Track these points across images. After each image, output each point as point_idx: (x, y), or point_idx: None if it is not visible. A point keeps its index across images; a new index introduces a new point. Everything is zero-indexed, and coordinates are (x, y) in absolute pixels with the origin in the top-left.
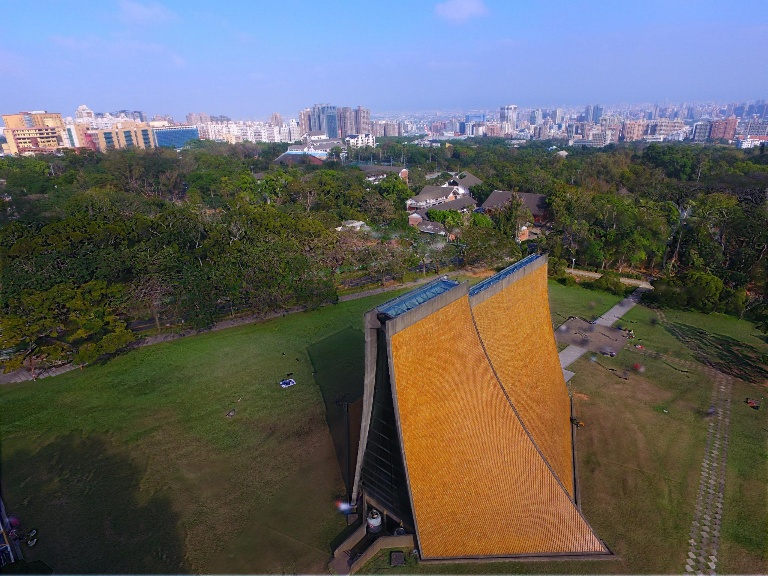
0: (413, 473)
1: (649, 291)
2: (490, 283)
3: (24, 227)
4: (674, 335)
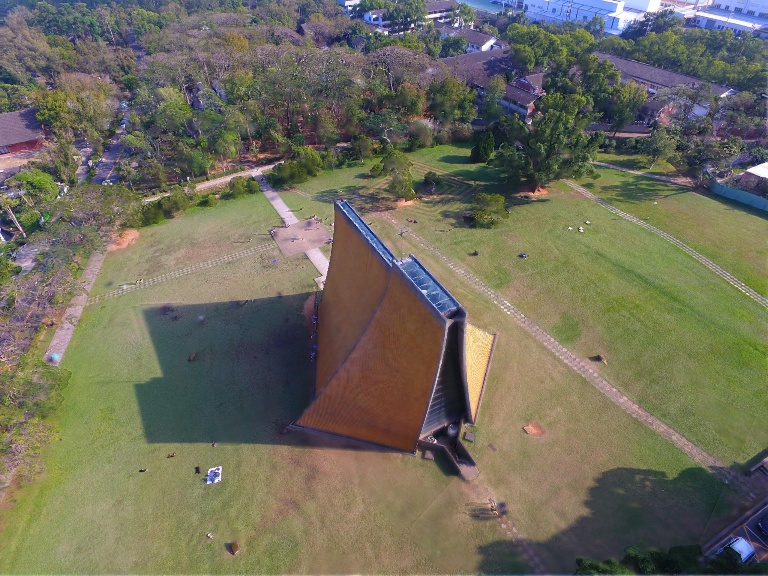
0: None
1: (264, 177)
2: None
3: None
4: (331, 203)
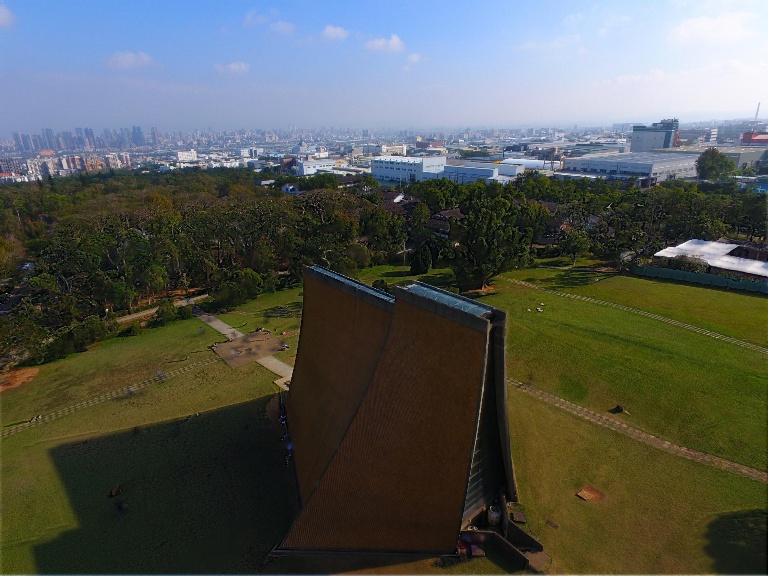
0: None
1: (197, 305)
2: None
3: None
4: (278, 317)
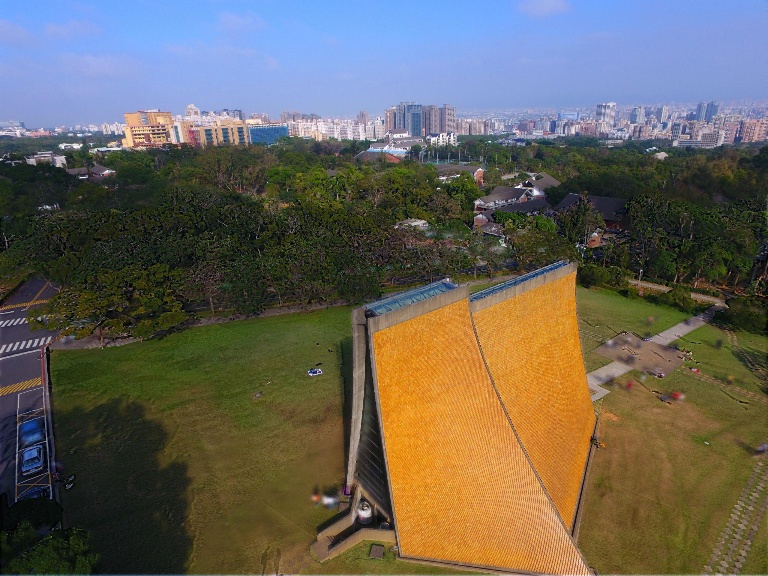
0: (394, 470)
1: (725, 310)
2: (502, 289)
3: (120, 214)
4: (742, 361)
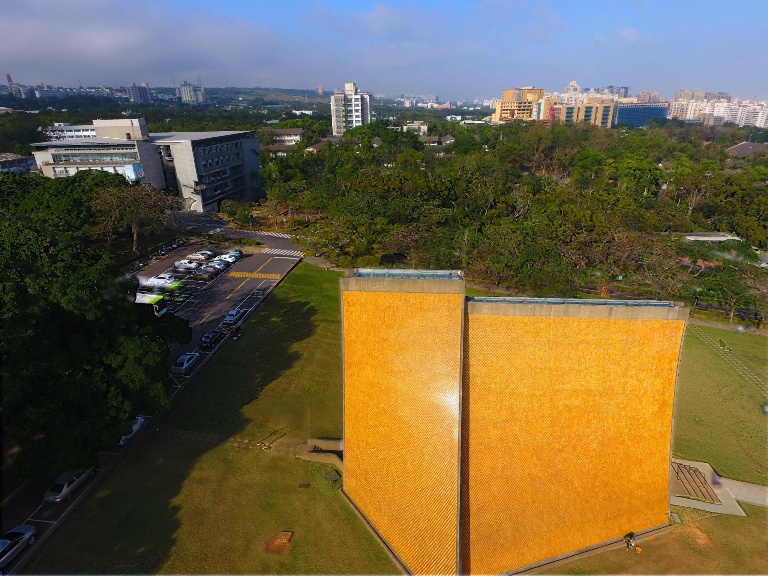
0: (348, 415)
1: None
2: None
3: None
4: None
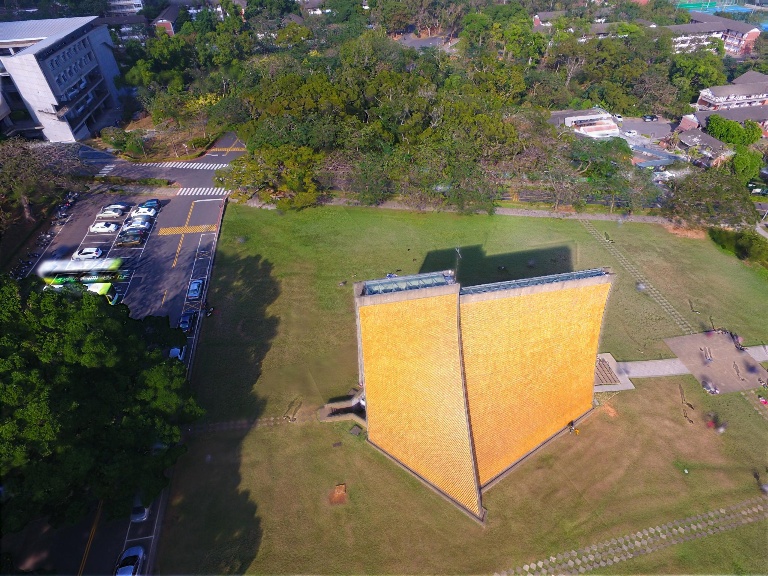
0: (369, 392)
1: None
2: (511, 285)
3: (309, 65)
4: None
